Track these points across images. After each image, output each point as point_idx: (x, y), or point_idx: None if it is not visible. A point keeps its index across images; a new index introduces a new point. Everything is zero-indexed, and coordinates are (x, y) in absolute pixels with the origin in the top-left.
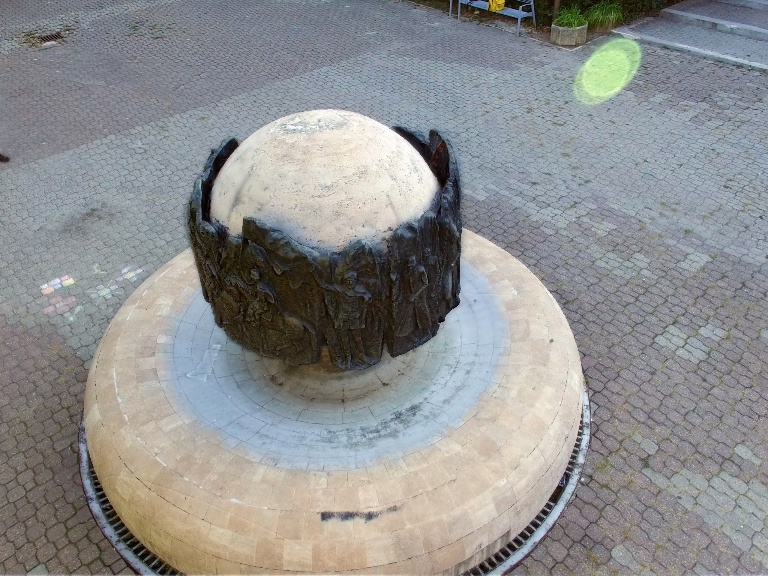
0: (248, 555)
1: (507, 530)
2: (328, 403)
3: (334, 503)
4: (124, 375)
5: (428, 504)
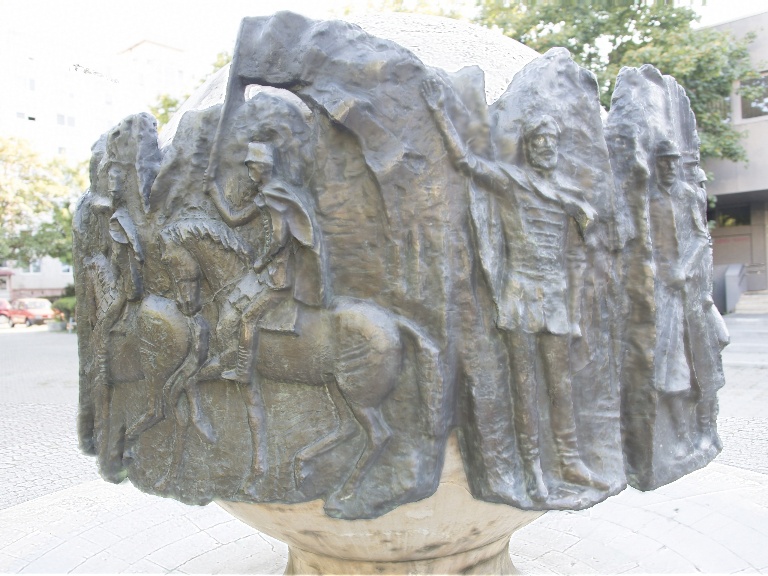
0: None
1: None
2: None
3: None
4: None
5: None
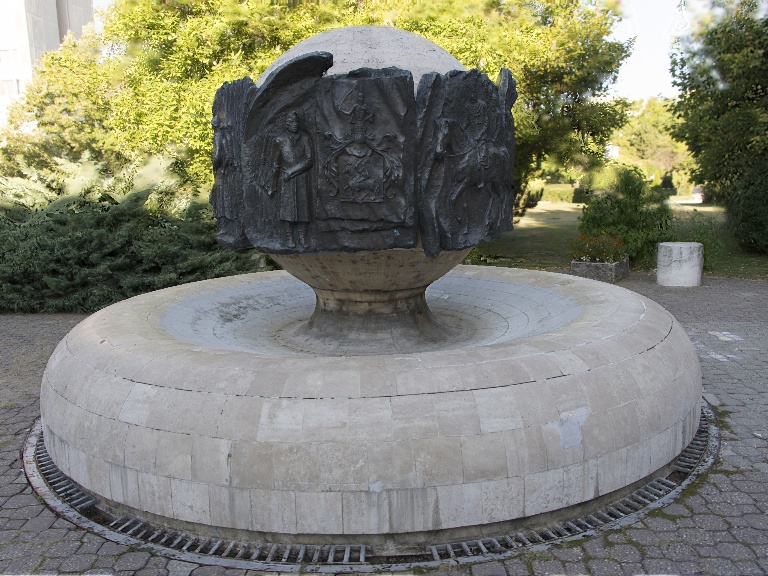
0: None
1: None
2: None
3: None
4: None
5: None
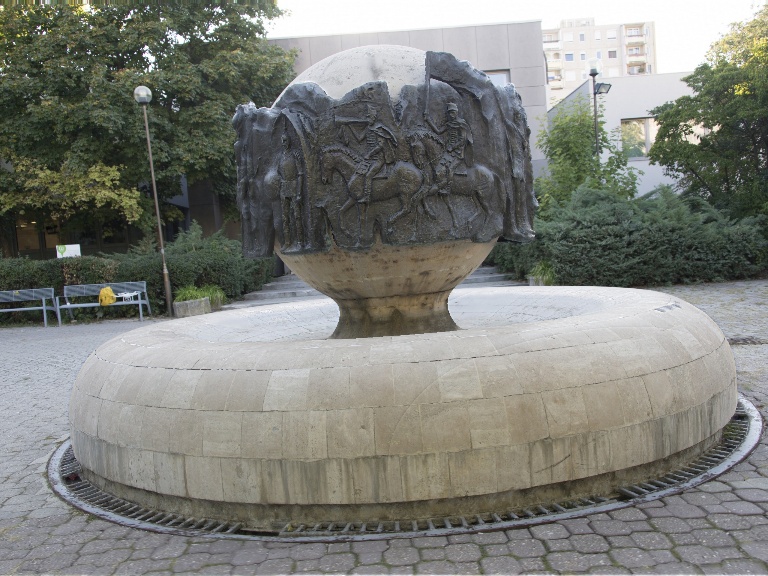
0: (663, 355)
1: None
2: None
3: None
4: (270, 345)
5: None
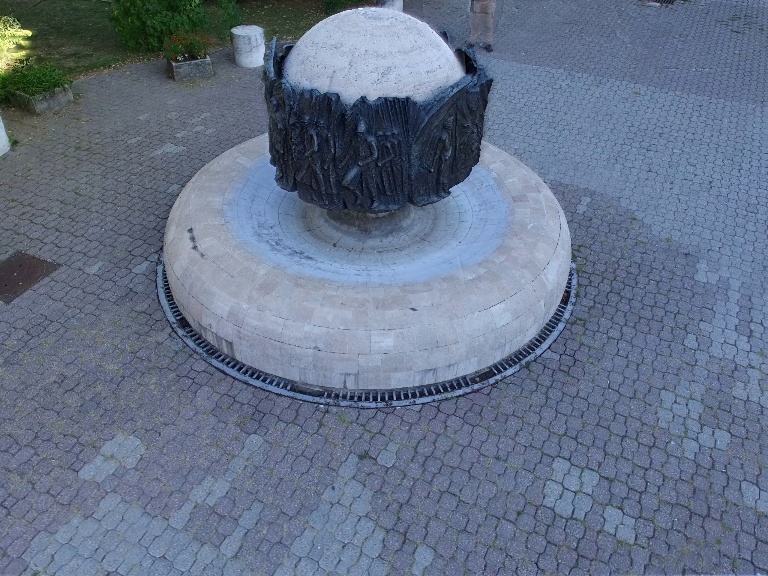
0: None
1: (230, 340)
2: (304, 224)
3: (199, 230)
4: None
5: (211, 270)
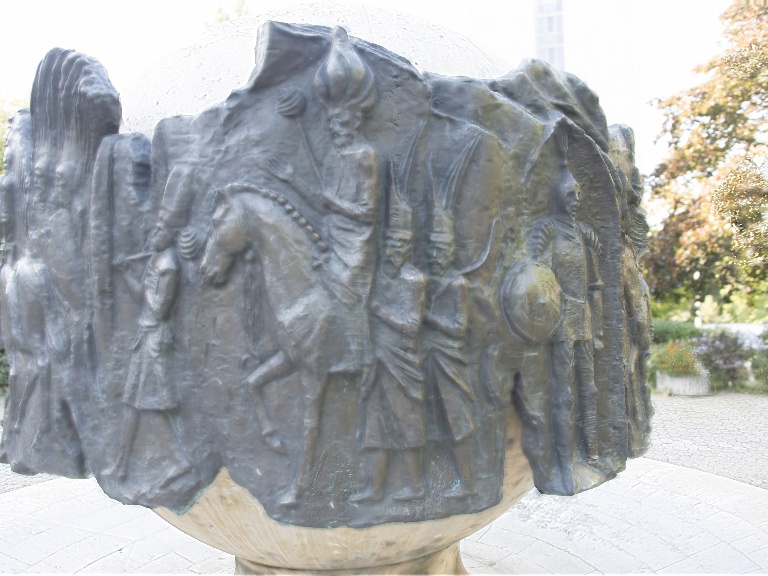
0: None
1: None
2: (517, 572)
3: None
4: None
5: None
